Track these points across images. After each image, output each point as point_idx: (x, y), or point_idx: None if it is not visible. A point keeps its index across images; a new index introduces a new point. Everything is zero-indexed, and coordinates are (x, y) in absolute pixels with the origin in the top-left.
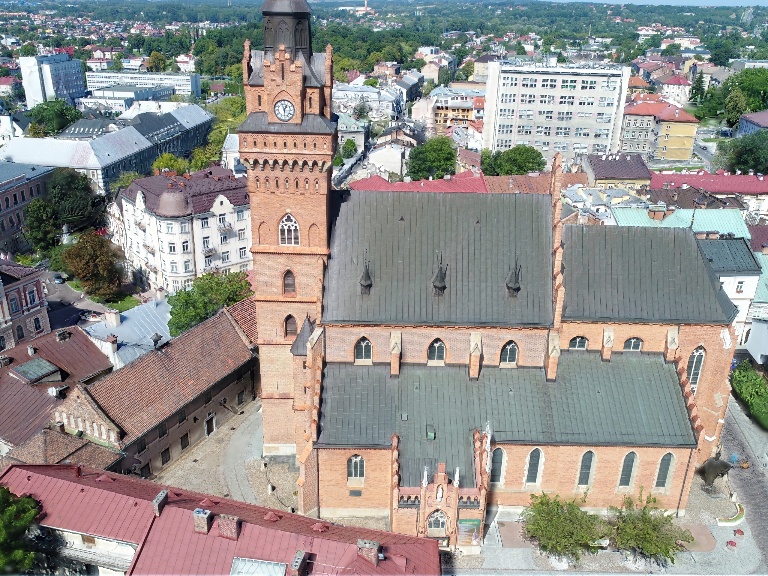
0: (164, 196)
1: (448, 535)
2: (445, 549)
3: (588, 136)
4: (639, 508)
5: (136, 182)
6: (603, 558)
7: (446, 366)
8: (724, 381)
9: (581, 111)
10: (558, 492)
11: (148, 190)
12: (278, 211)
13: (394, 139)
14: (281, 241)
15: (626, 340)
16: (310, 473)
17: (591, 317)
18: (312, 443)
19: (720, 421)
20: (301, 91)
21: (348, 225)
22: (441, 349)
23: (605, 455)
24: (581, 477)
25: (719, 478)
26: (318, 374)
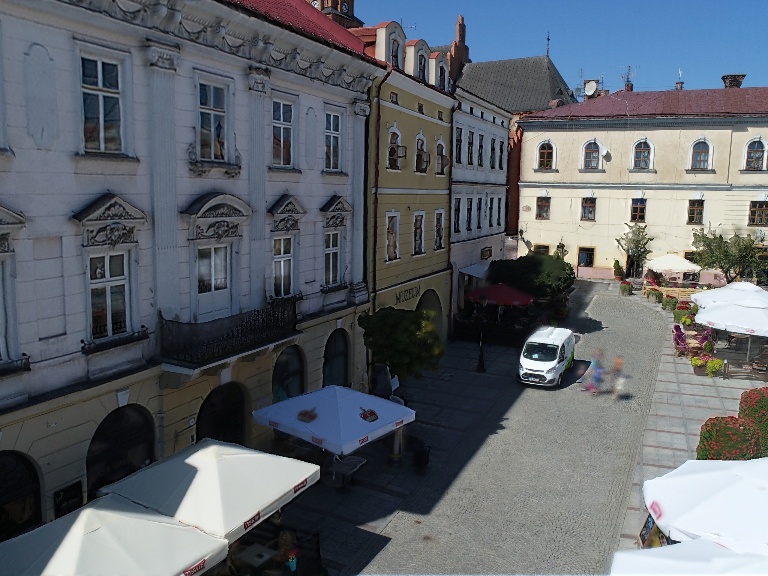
0: None
1: None
2: None
3: None
4: None
5: None
6: None
7: None
8: None
9: None
10: None
11: None
12: None
13: None
14: None
15: None
16: None
17: None
18: None
19: None
20: None
21: None
22: None
23: None
24: None
25: None
26: None
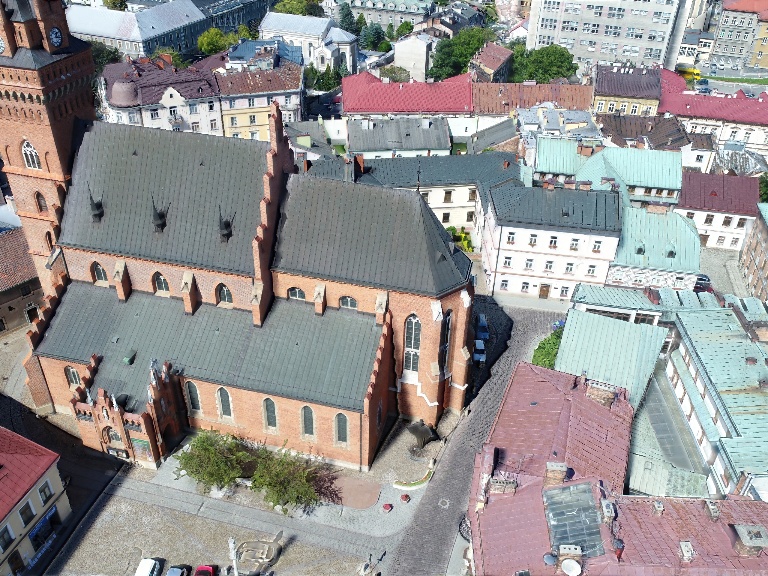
0: (114, 86)
1: (126, 449)
2: (126, 460)
3: (641, 38)
4: (326, 456)
5: (107, 67)
6: (260, 495)
7: (171, 298)
8: (460, 350)
9: (635, 8)
10: (250, 428)
11: (110, 77)
12: (17, 137)
13: (430, 28)
14: (28, 164)
15: (341, 297)
16: (35, 375)
17: (302, 271)
18: (32, 350)
19: (460, 387)
20: (8, 25)
21: (89, 155)
22: (167, 282)
23: (283, 404)
24: (269, 419)
25: (437, 442)
26: (53, 290)
